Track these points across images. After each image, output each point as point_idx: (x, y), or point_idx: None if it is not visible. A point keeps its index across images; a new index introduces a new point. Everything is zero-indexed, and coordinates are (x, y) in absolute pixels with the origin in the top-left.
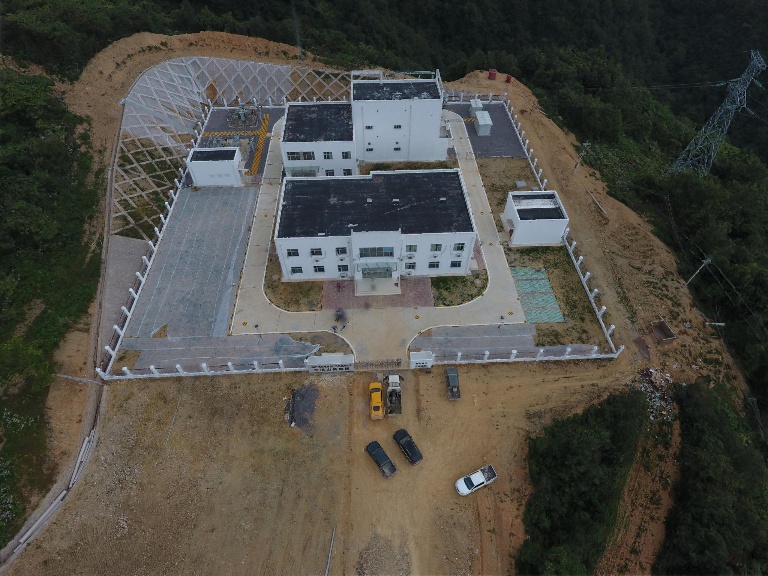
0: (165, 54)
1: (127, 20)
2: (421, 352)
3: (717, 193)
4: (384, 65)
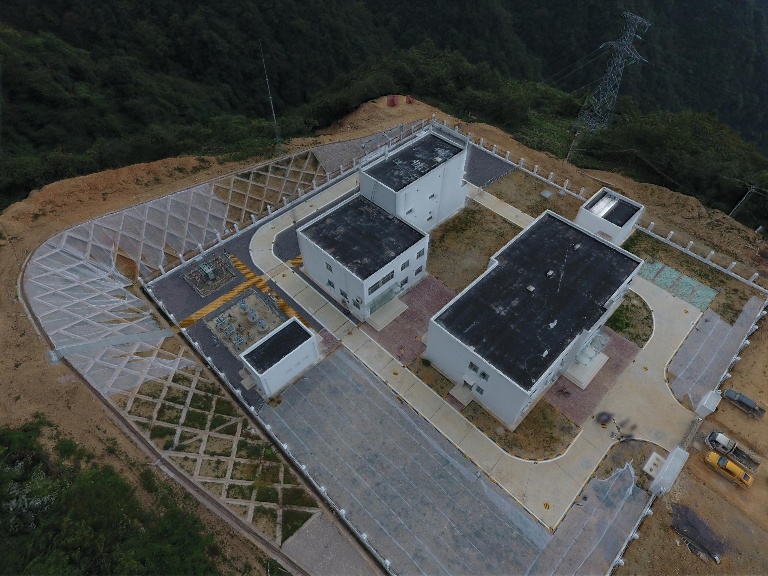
0: (11, 250)
1: None
2: (708, 398)
3: (666, 131)
4: (288, 134)
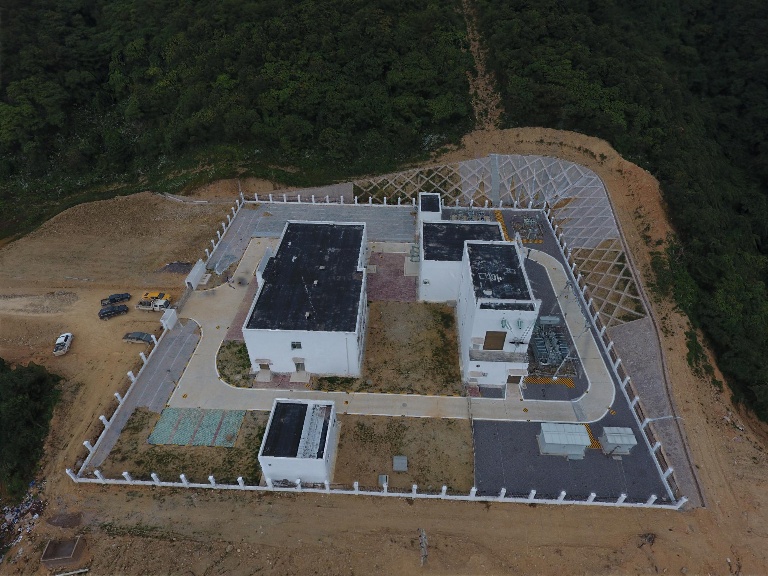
0: (592, 162)
1: (597, 124)
2: (171, 315)
3: None
4: None
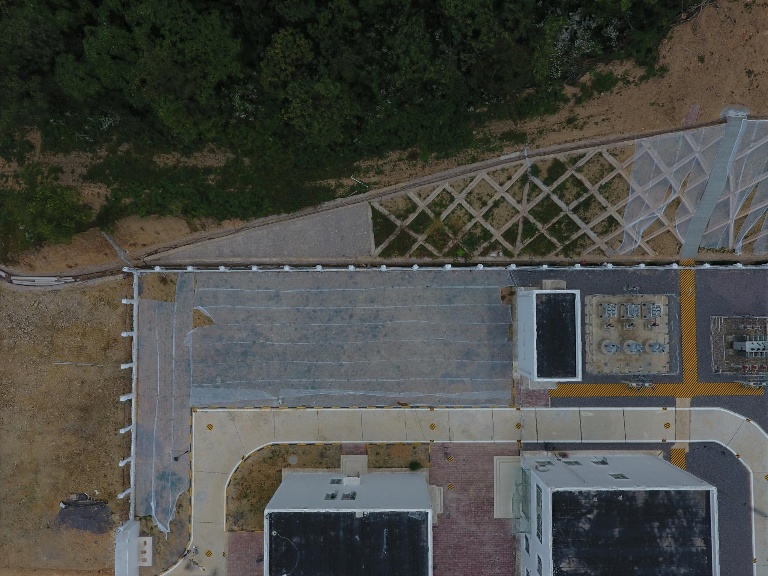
0: None
1: None
2: None
3: None
4: None
